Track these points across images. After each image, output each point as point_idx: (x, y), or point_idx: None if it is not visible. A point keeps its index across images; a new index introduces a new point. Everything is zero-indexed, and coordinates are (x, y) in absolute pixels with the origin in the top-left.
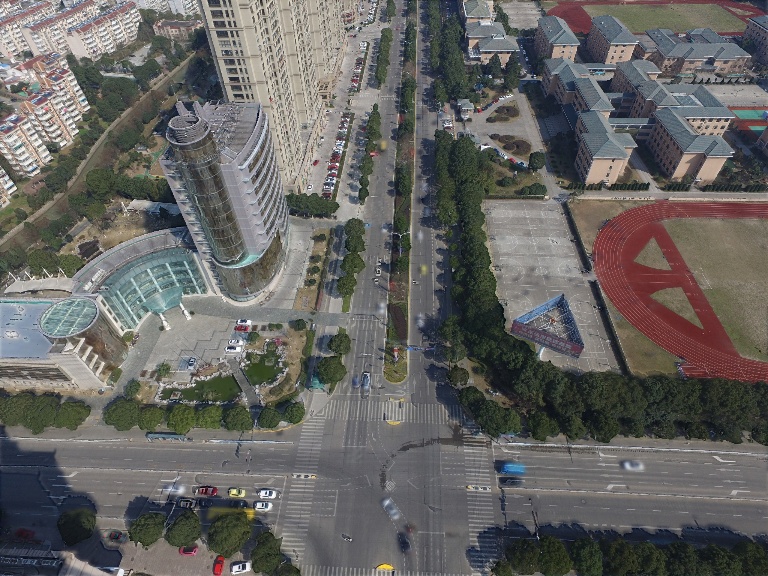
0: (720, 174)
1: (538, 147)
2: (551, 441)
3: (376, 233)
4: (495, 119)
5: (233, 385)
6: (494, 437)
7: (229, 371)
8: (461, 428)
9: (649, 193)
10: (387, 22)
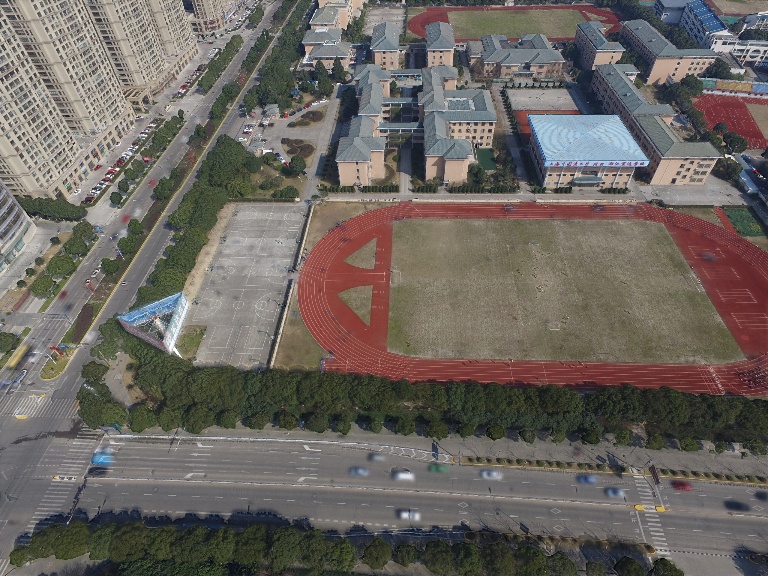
0: (474, 176)
1: (321, 151)
2: (159, 433)
3: (116, 236)
4: (295, 124)
5: None
6: (95, 429)
7: None
8: (83, 422)
9: (398, 195)
10: (252, 29)
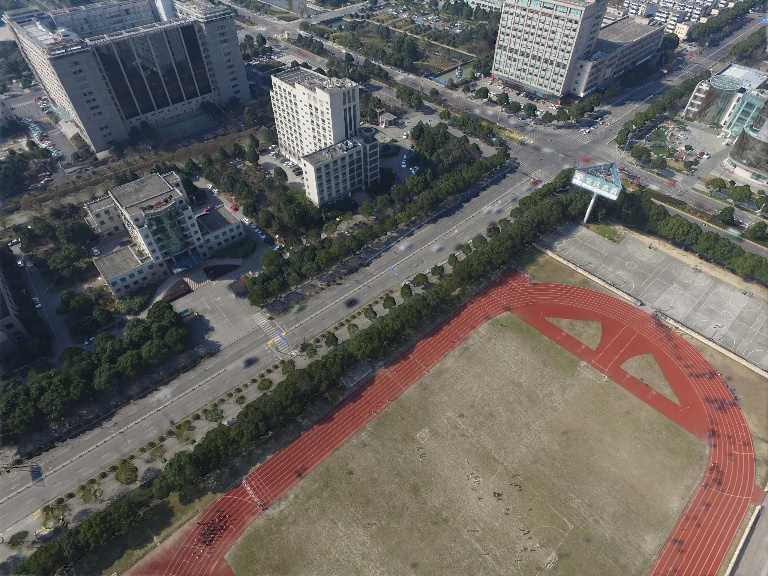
0: None
1: None
2: None
3: None
4: None
5: None
6: None
7: (668, 143)
8: None
9: None
10: None
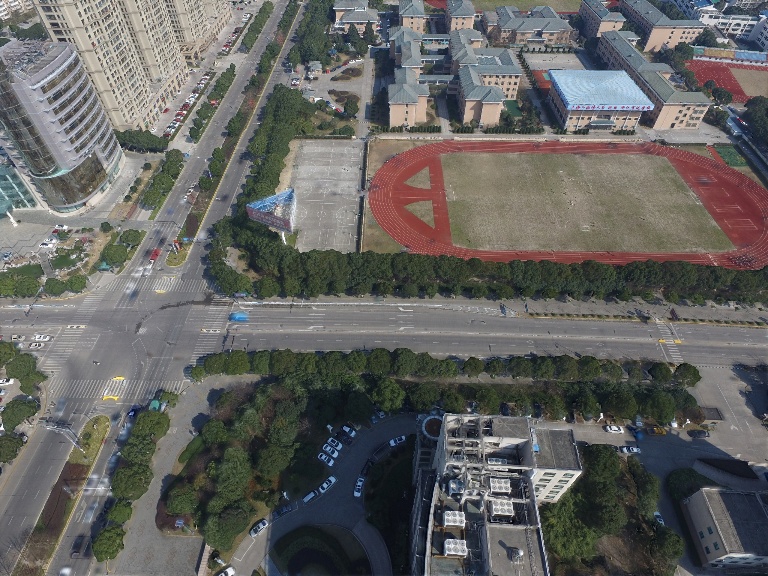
0: (504, 120)
1: (366, 100)
2: (279, 301)
3: (199, 164)
4: (338, 78)
5: (39, 270)
6: None
7: (38, 260)
8: (213, 294)
9: (441, 135)
10: None
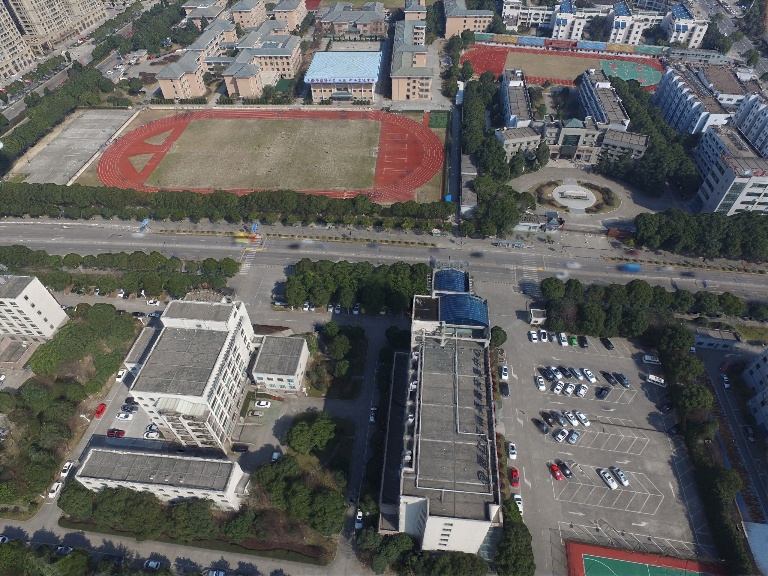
0: None
1: None
2: None
3: None
4: (155, 63)
5: None
6: None
7: None
8: None
9: (205, 105)
10: None
